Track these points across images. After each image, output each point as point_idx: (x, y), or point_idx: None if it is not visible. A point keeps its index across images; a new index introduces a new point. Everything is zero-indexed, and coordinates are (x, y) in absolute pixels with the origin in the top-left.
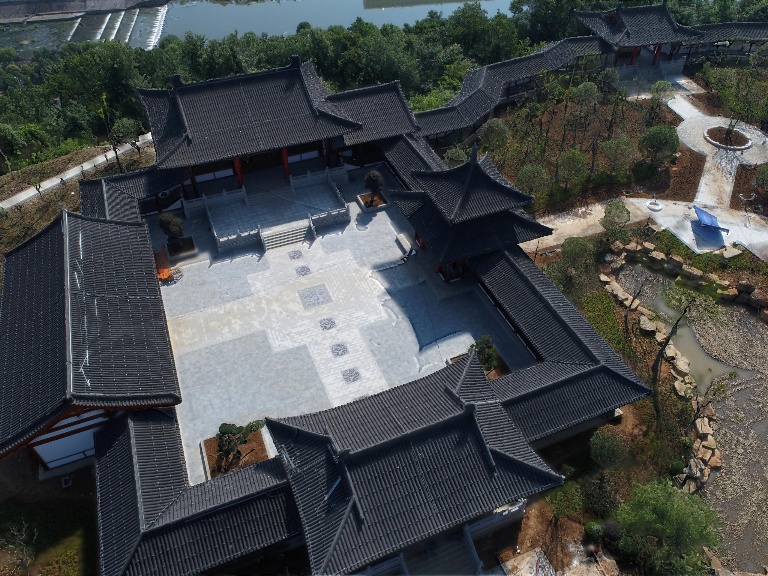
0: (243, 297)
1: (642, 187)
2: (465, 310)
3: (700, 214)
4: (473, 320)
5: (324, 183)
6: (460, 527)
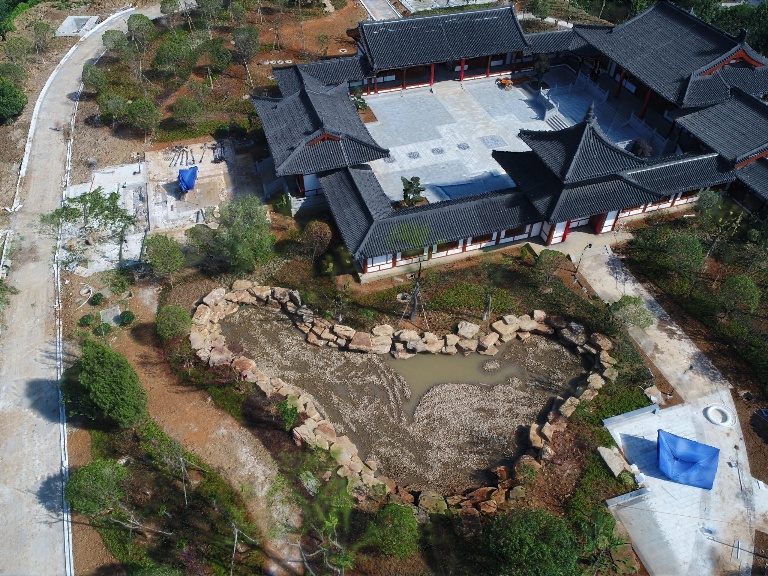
0: (489, 113)
1: (767, 415)
2: None
3: (697, 449)
4: None
5: None
6: (285, 177)
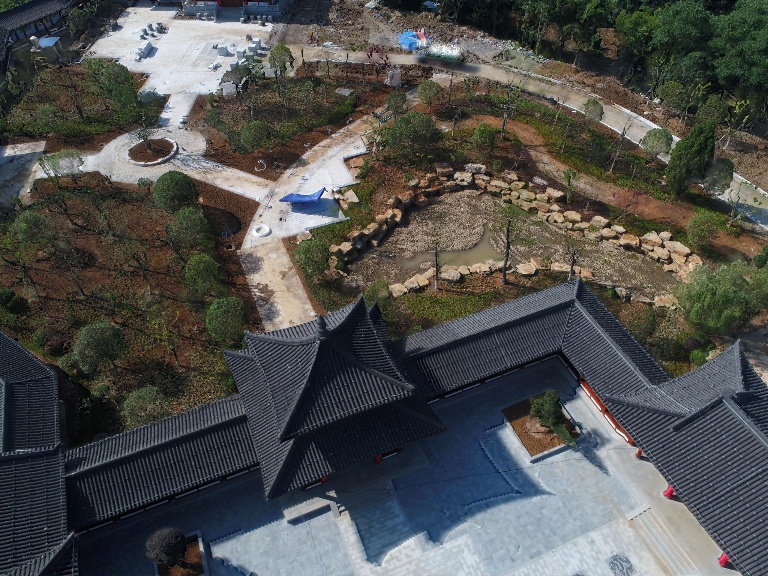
0: None
1: (225, 233)
2: (442, 435)
3: None
4: (459, 428)
5: None
6: None
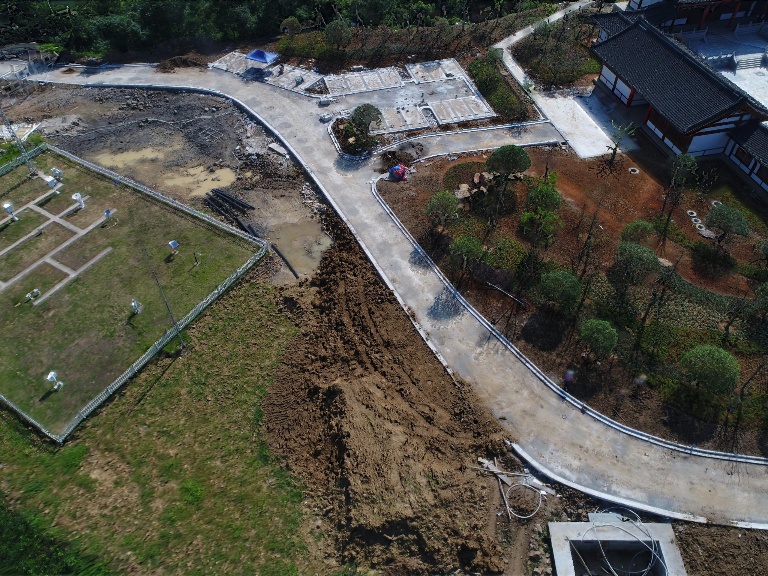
0: None
1: None
2: None
3: None
4: None
5: (756, 34)
6: None
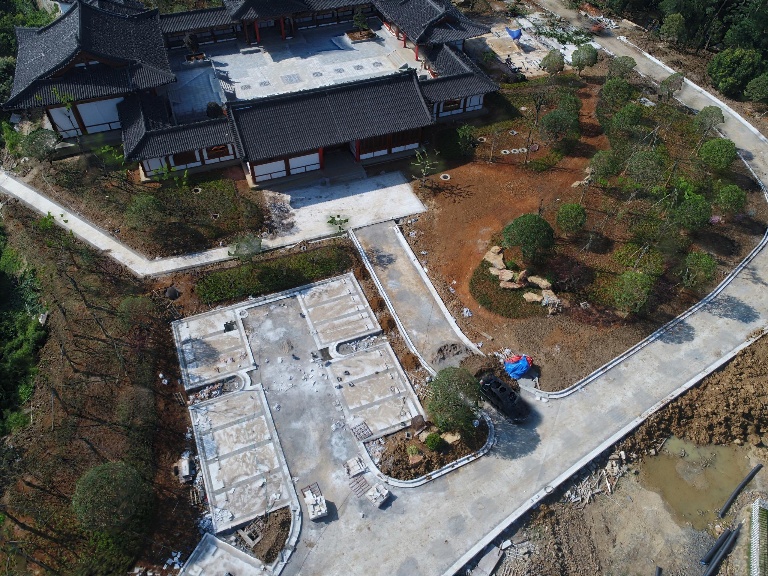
0: None
1: None
2: (315, 37)
3: None
4: (324, 36)
5: None
6: None
